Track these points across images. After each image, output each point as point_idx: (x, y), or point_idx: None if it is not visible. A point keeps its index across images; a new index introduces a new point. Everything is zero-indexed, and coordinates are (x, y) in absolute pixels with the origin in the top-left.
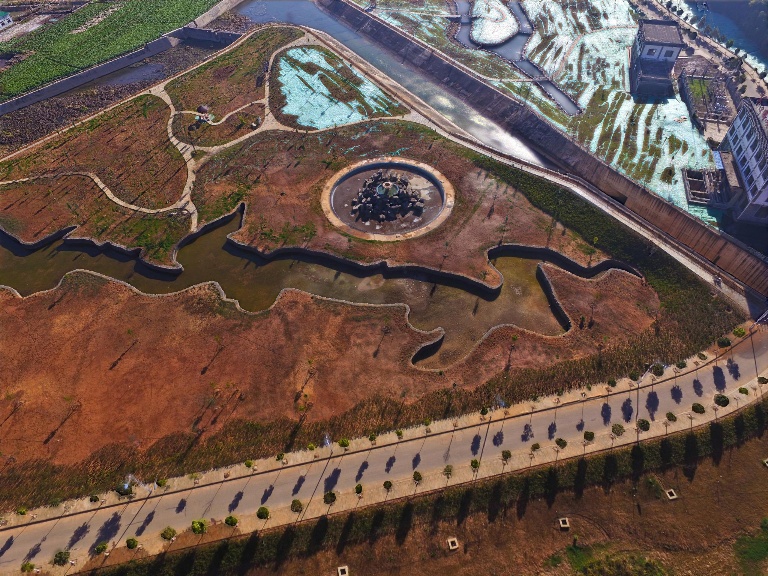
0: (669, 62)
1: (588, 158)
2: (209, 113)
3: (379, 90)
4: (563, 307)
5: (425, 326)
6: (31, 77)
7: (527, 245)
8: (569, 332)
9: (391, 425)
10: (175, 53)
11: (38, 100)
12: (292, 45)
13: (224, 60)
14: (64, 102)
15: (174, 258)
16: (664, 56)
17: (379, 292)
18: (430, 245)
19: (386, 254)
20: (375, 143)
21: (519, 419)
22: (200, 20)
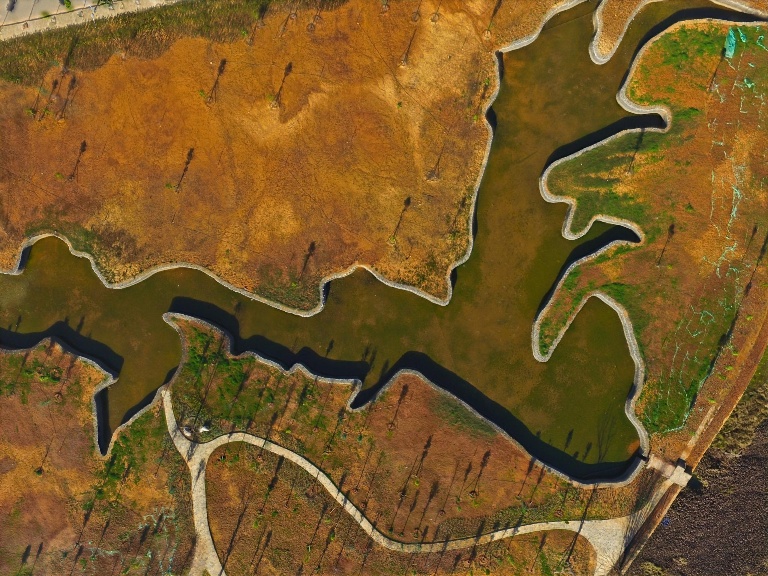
0: None
1: None
2: None
3: None
4: None
5: None
6: None
7: None
8: None
9: None
10: None
11: None
12: None
13: None
14: None
15: None
16: None
17: None
18: None
19: None
20: None
21: None
22: None
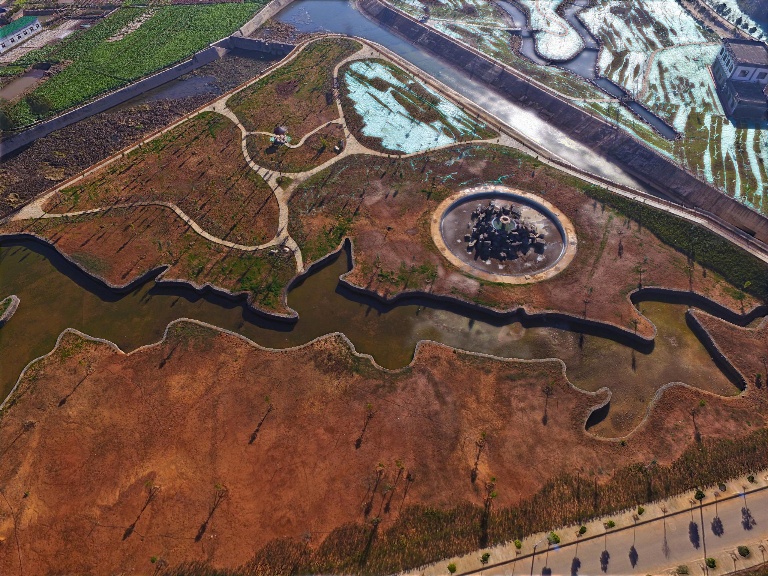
0: (761, 84)
1: (706, 189)
2: (284, 134)
3: (460, 110)
4: (731, 362)
5: (585, 384)
6: (75, 90)
7: (670, 288)
8: (747, 392)
9: (592, 511)
10: (224, 64)
11: (86, 116)
12: (353, 58)
13: (284, 74)
14: (115, 118)
15: (286, 304)
16: (756, 78)
17: (523, 344)
18: (566, 289)
19: (521, 299)
20: (473, 170)
21: (733, 502)
22: (245, 29)
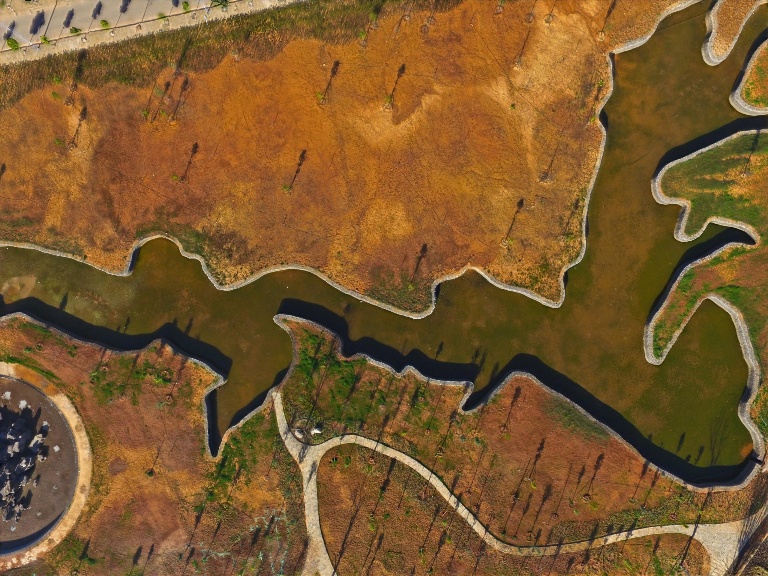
0: None
1: None
2: None
3: None
4: None
5: None
6: None
7: None
8: None
9: None
10: None
11: None
12: None
13: None
14: None
15: None
16: None
17: (8, 272)
18: None
19: None
20: None
21: None
22: None
